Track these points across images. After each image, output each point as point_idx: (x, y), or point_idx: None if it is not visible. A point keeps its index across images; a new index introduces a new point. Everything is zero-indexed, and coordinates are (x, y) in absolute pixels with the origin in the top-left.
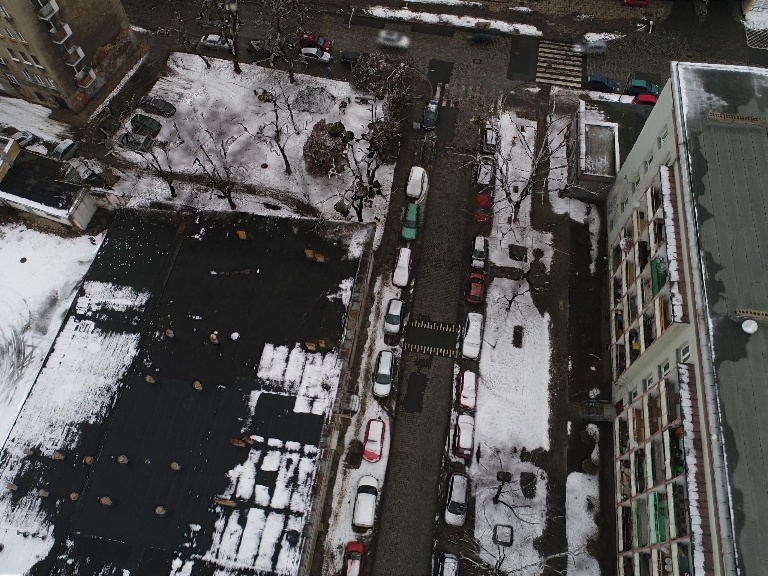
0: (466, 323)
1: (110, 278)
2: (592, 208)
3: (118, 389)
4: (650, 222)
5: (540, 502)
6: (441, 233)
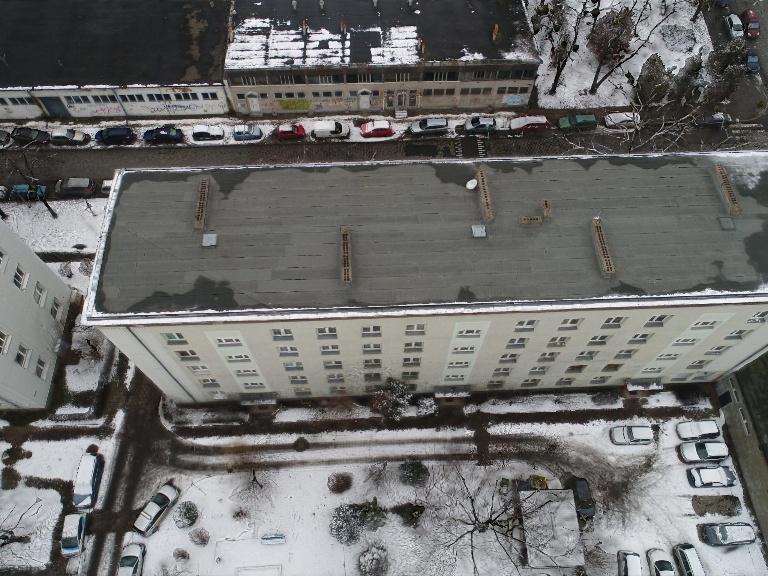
0: None
1: None
2: None
3: None
4: None
5: None
6: None
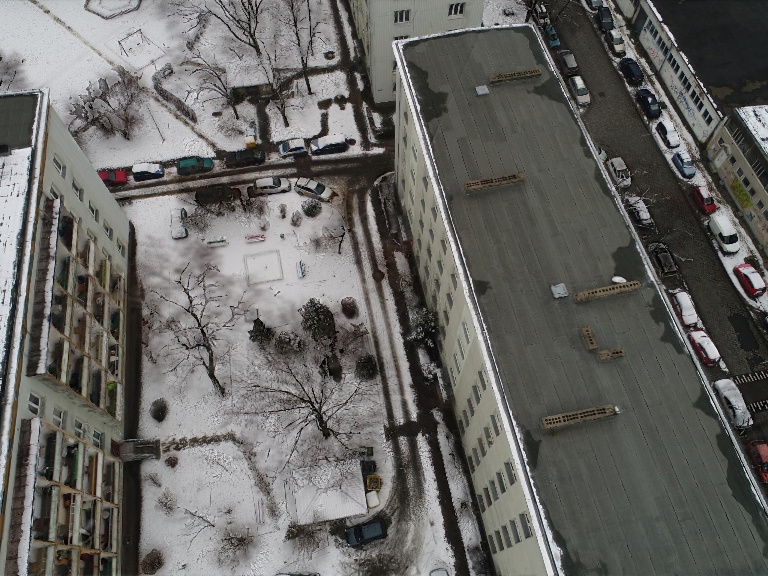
0: None
1: None
2: None
3: None
4: None
5: None
6: None
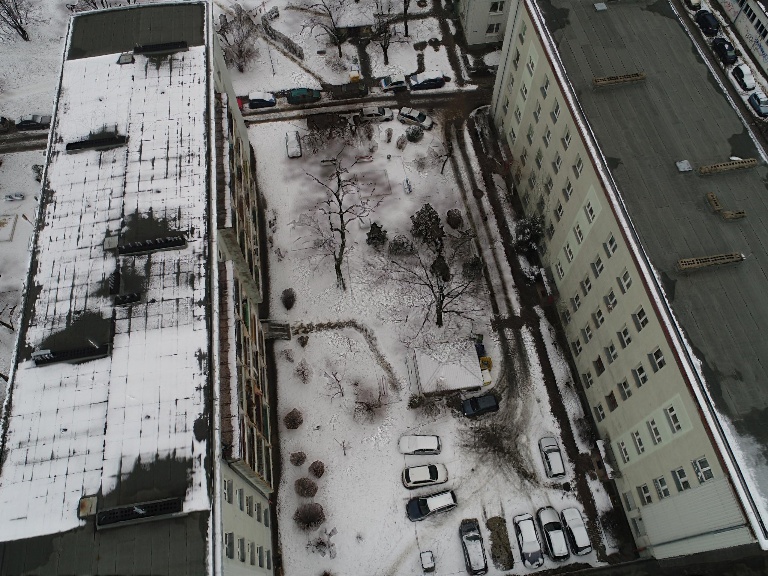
0: None
1: None
2: None
3: None
4: None
5: None
6: None
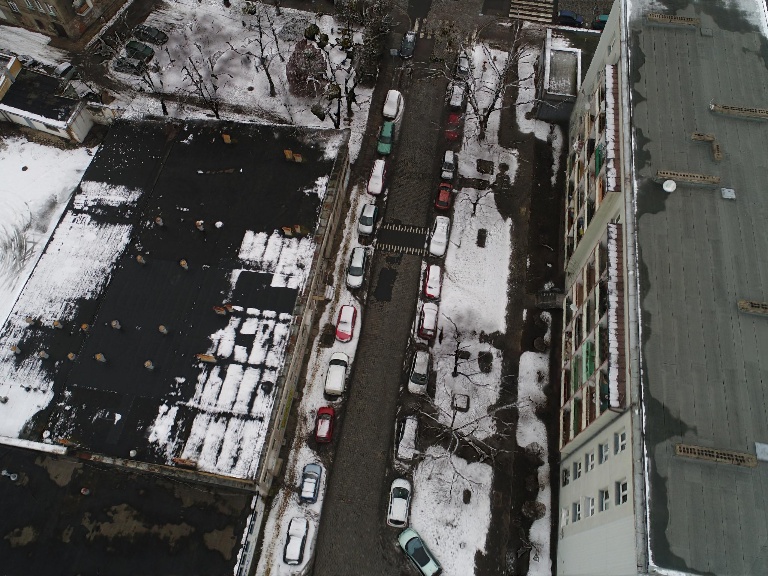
0: (434, 225)
1: (105, 178)
2: (556, 128)
3: (112, 271)
4: (596, 117)
5: (495, 376)
6: (414, 149)
